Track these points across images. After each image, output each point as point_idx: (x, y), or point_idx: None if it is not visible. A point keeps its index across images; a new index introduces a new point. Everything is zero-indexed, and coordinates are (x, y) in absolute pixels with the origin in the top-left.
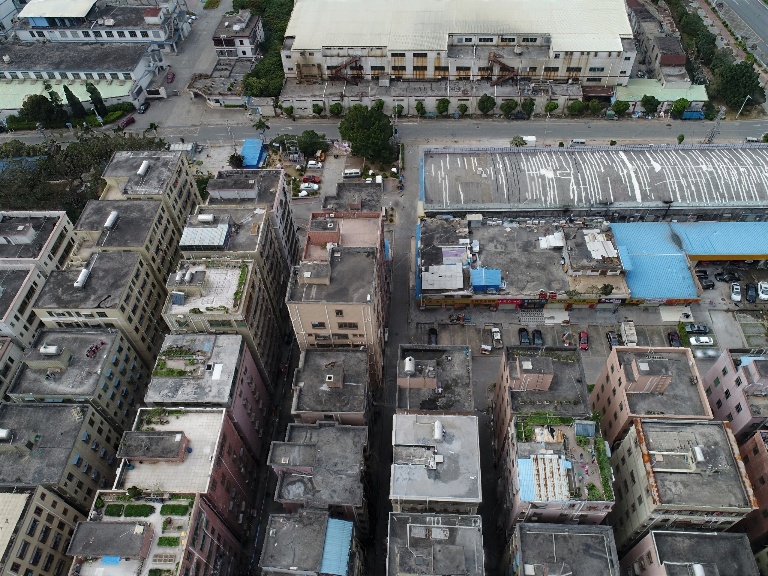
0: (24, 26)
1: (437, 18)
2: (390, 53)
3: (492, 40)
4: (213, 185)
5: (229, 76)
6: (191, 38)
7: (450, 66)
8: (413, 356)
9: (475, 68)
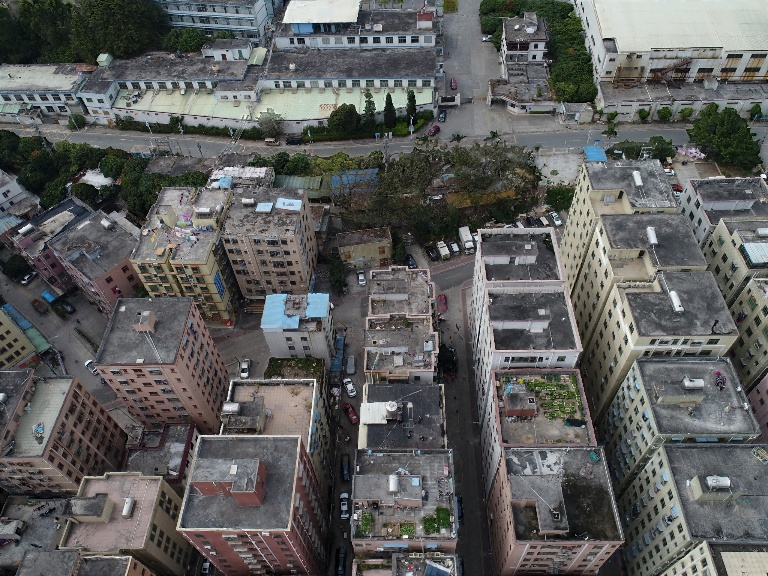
0: (284, 33)
1: (759, 17)
2: (726, 54)
3: None
4: (707, 196)
5: (528, 81)
6: (449, 43)
7: None
8: None
9: None
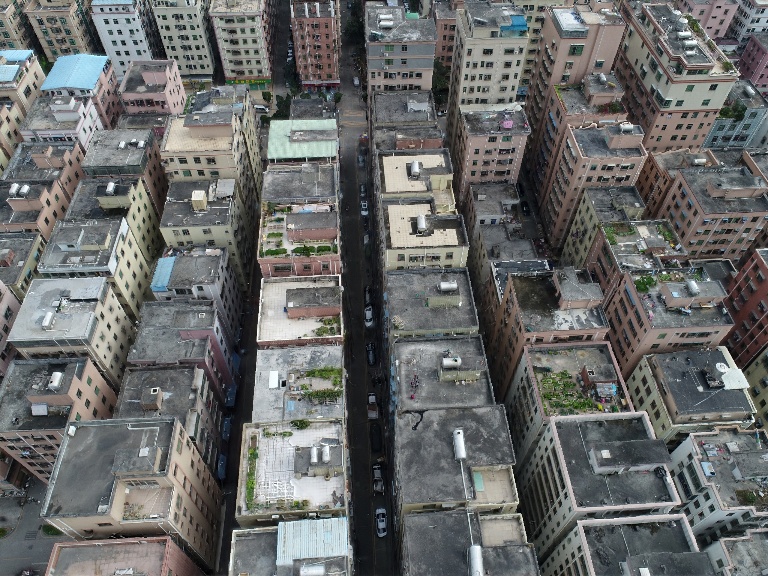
0: None
1: None
2: None
3: None
4: None
5: None
6: None
7: None
8: (56, 422)
9: None
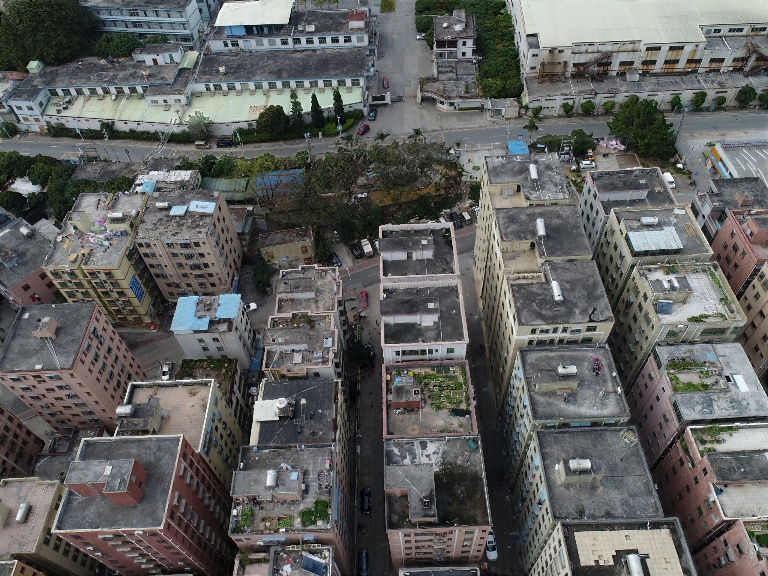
0: (217, 36)
1: (678, 10)
2: (645, 47)
3: (742, 30)
4: (603, 187)
5: (457, 78)
6: (384, 42)
7: (704, 58)
8: None
9: (729, 59)
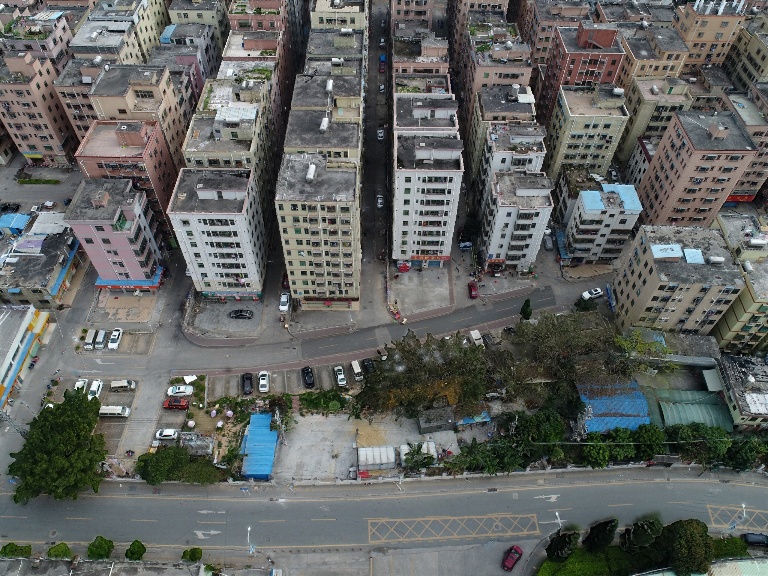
0: None
1: None
2: None
3: None
4: (242, 183)
5: None
6: None
7: None
8: None
9: None
